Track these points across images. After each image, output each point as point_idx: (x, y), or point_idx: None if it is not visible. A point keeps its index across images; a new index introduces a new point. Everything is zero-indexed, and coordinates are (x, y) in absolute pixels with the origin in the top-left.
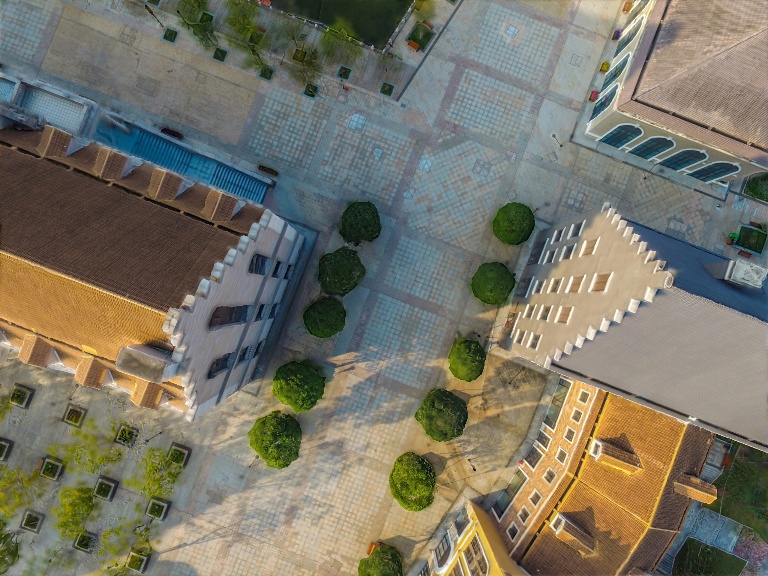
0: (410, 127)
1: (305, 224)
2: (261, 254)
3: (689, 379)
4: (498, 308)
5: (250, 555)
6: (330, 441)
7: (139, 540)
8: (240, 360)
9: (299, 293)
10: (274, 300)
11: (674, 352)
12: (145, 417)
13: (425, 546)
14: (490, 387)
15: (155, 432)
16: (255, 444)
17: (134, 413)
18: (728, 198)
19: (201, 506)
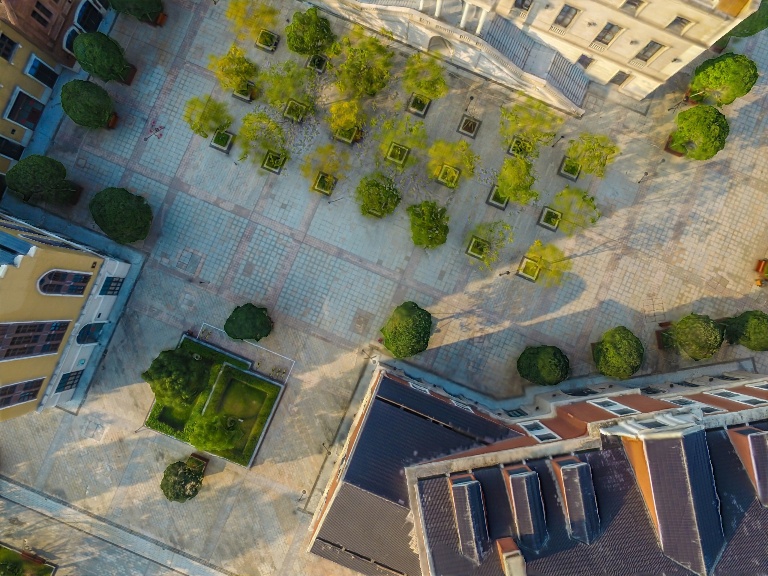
0: None
1: None
2: None
3: None
4: None
5: (639, 268)
6: (717, 161)
7: (531, 249)
8: None
9: None
10: None
11: None
12: (538, 130)
13: None
14: None
15: (547, 145)
16: (696, 123)
17: (527, 126)
18: None
19: None
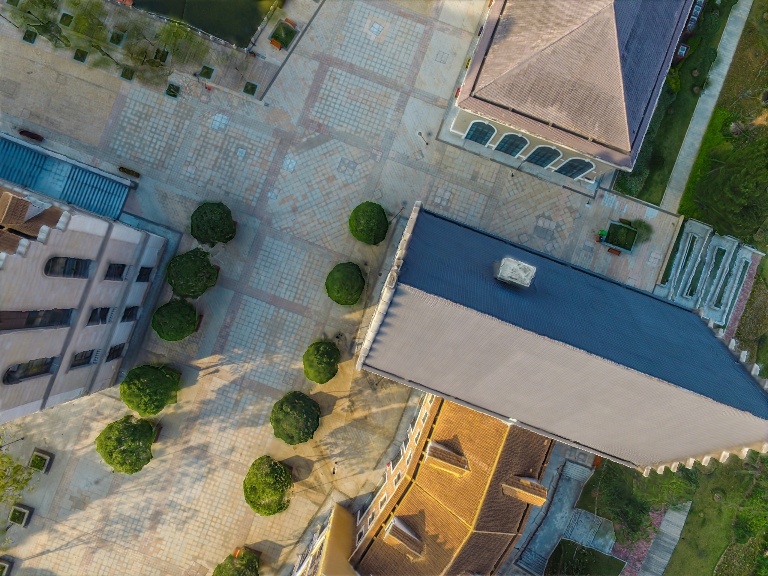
0: (274, 126)
1: (168, 226)
2: (71, 257)
3: (483, 380)
4: (365, 309)
5: (114, 561)
6: (195, 445)
7: (1, 547)
8: (78, 364)
9: (162, 296)
10: (126, 303)
11: (453, 353)
12: (7, 423)
13: (292, 550)
14: (357, 389)
15: (17, 438)
16: (100, 449)
17: None
18: (597, 195)
19: (64, 512)
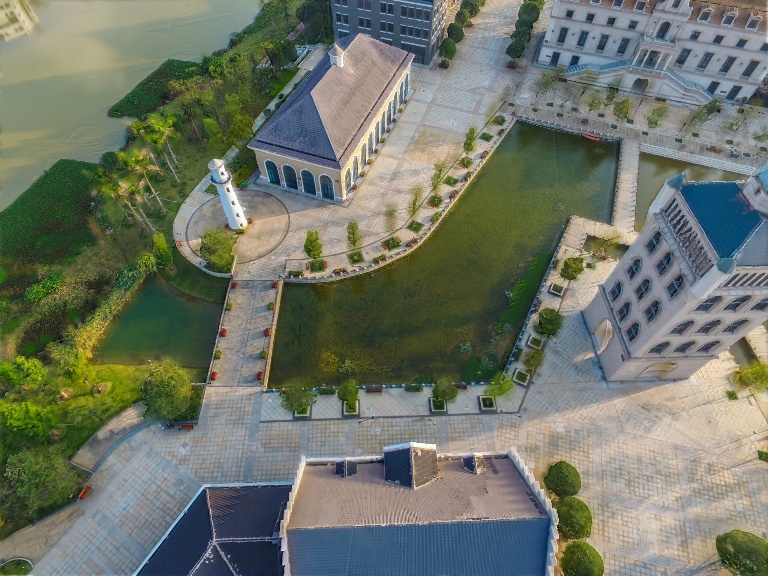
0: (497, 94)
1: None
2: None
3: None
4: None
5: None
6: None
7: None
8: None
9: (535, 51)
10: None
11: None
12: None
13: None
14: None
15: None
16: None
17: None
18: None
19: None
